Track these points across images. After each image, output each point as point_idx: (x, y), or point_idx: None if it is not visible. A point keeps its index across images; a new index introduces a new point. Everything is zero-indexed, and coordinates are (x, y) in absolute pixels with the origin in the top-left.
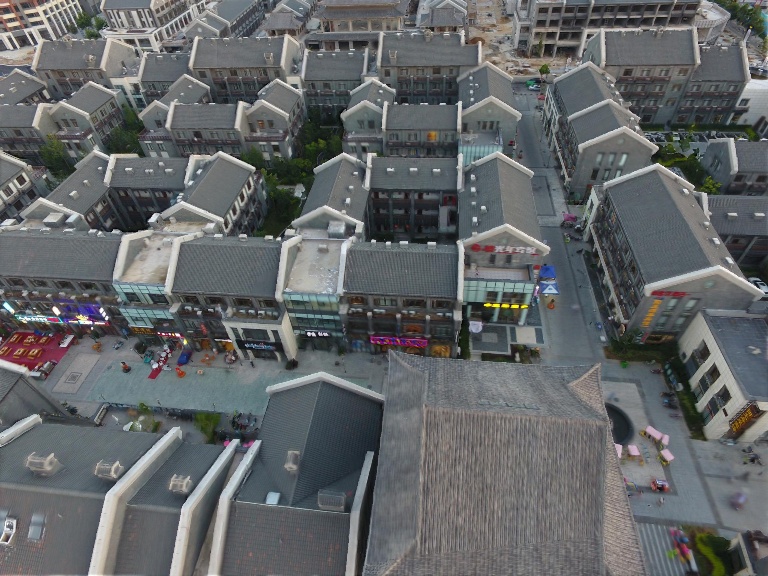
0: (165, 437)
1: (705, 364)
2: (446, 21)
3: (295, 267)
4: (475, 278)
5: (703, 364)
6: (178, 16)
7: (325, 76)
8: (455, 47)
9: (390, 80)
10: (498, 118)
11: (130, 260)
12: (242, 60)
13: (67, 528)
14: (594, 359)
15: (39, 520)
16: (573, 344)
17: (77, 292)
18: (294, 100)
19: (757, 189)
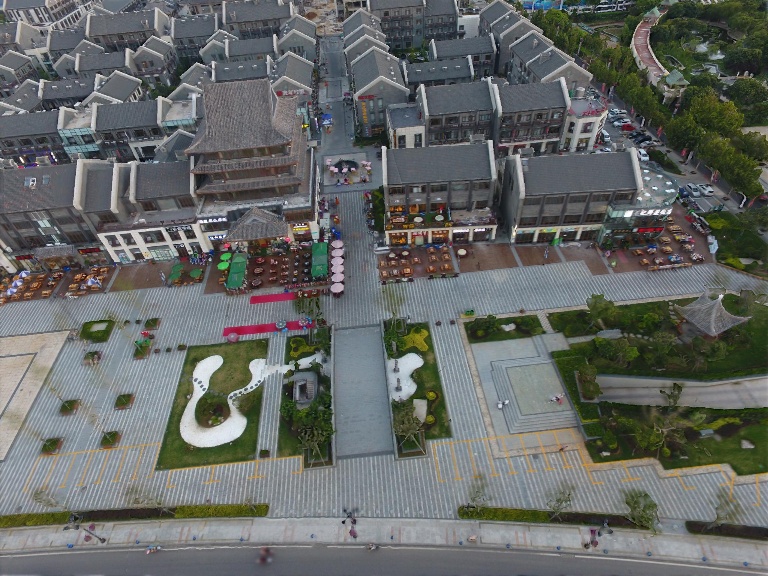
0: None
1: None
2: None
3: (169, 113)
4: None
5: None
6: (70, 13)
7: (189, 35)
8: (275, 7)
9: (235, 33)
10: (301, 44)
11: (66, 122)
12: (126, 27)
13: (61, 178)
14: (346, 147)
15: (47, 177)
16: (337, 144)
17: (34, 146)
18: (167, 49)
19: None
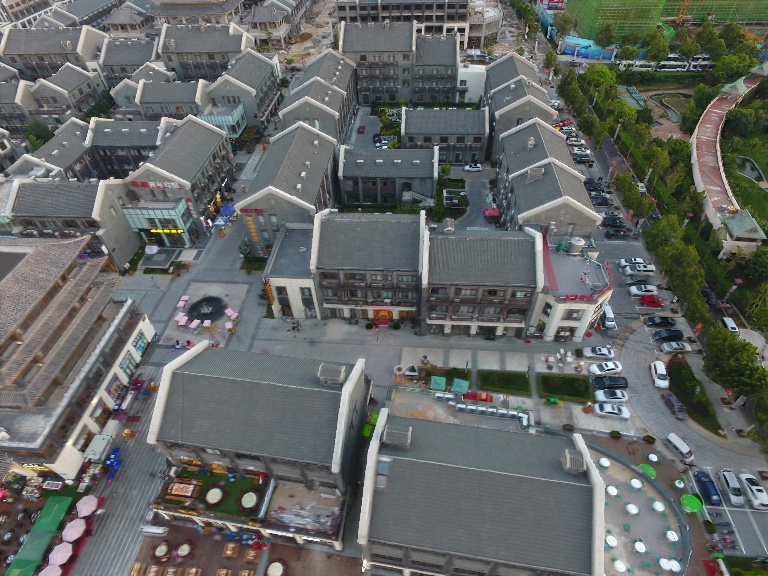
0: None
1: None
2: (265, 17)
3: None
4: (133, 207)
5: None
6: (38, 12)
7: (121, 61)
8: (225, 36)
9: (174, 65)
10: (237, 94)
11: None
12: (46, 47)
13: None
14: (229, 270)
15: None
16: (221, 260)
17: None
18: (81, 81)
19: (426, 148)
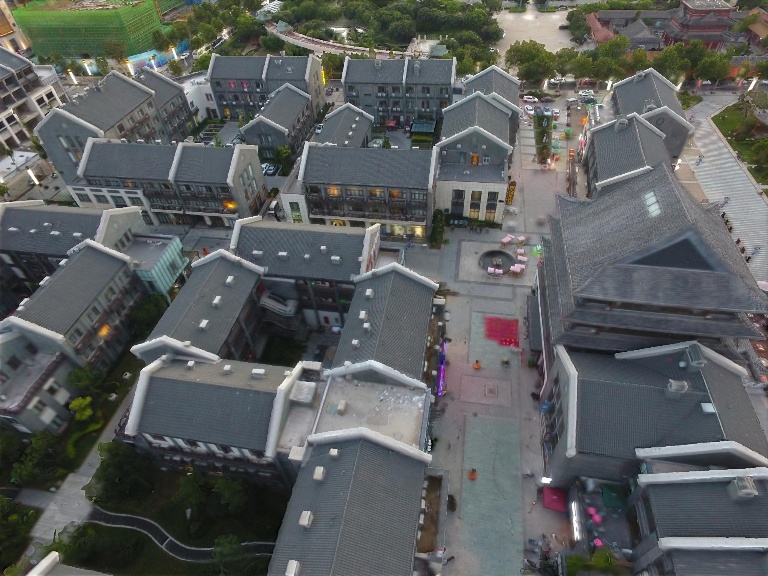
0: (690, 541)
1: (467, 198)
2: None
3: None
4: None
5: (465, 199)
6: None
7: None
8: None
9: None
10: (126, 226)
11: None
12: None
13: None
14: (441, 256)
15: None
16: (426, 263)
17: None
18: None
19: None
